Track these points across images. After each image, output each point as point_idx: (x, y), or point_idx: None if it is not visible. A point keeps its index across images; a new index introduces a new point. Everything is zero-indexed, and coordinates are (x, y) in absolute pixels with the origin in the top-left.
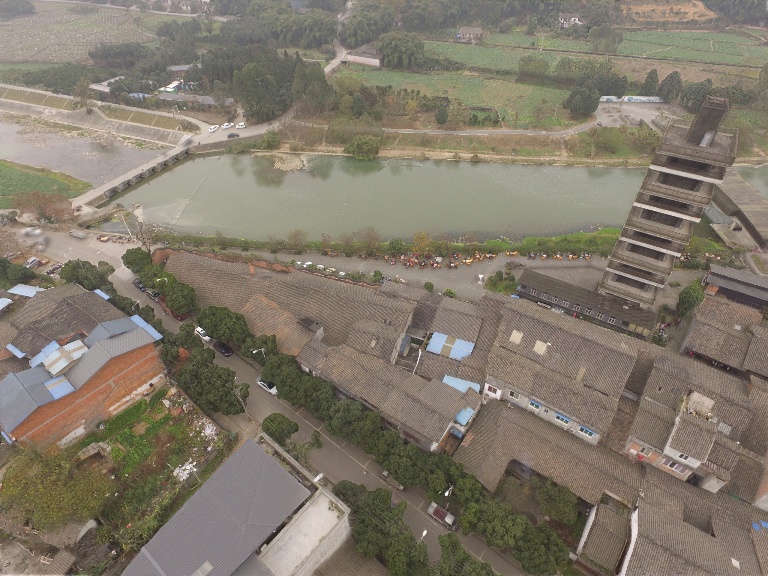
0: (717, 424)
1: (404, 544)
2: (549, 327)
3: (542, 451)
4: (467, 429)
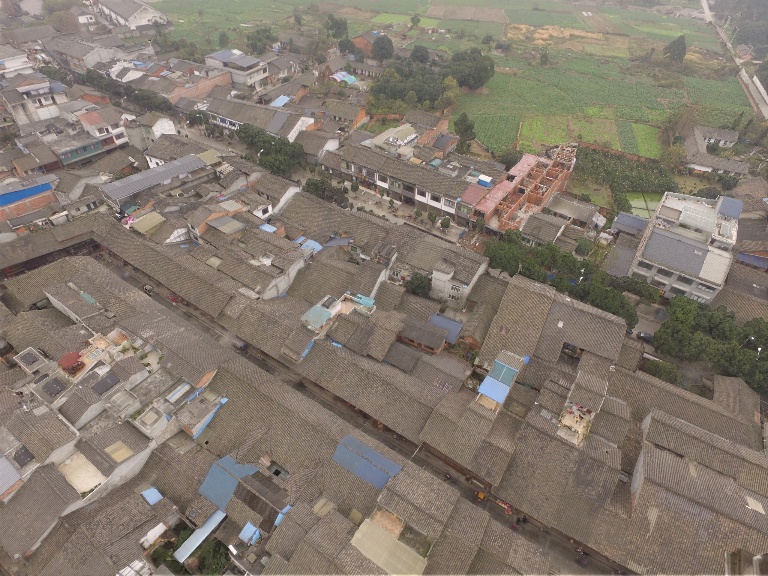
0: (552, 418)
1: (763, 329)
2: (765, 529)
3: (695, 399)
4: (763, 429)
